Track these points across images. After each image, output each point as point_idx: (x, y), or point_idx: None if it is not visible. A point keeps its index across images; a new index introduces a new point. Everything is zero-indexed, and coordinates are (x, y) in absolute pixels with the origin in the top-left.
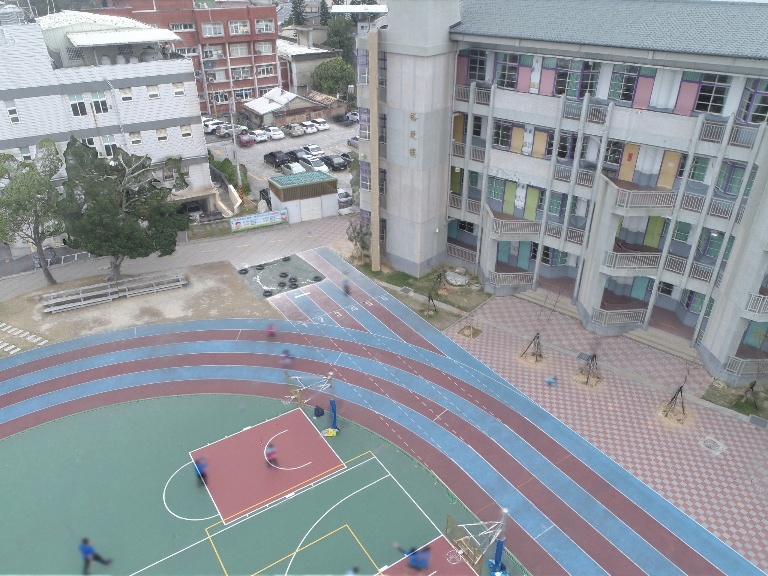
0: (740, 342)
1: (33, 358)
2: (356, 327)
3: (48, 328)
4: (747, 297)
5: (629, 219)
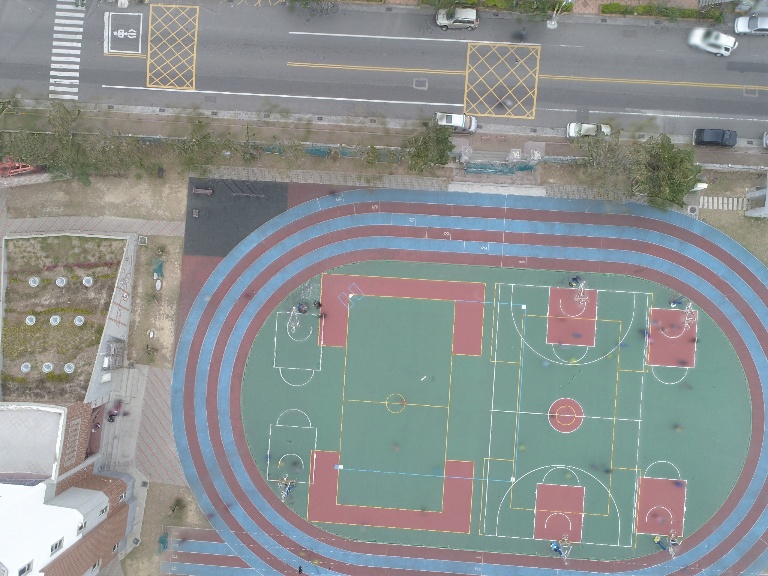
0: None
1: None
2: None
3: None
4: None
5: None
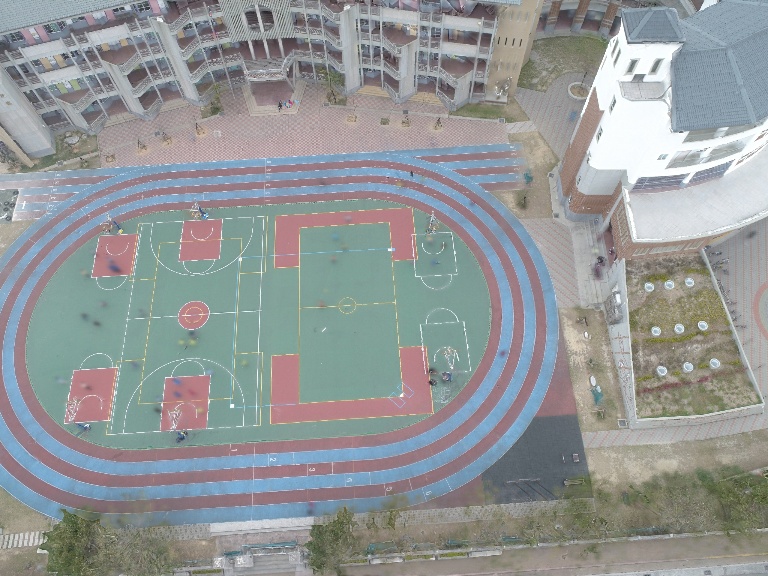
0: (197, 90)
1: None
2: (69, 196)
3: None
4: (188, 77)
5: None
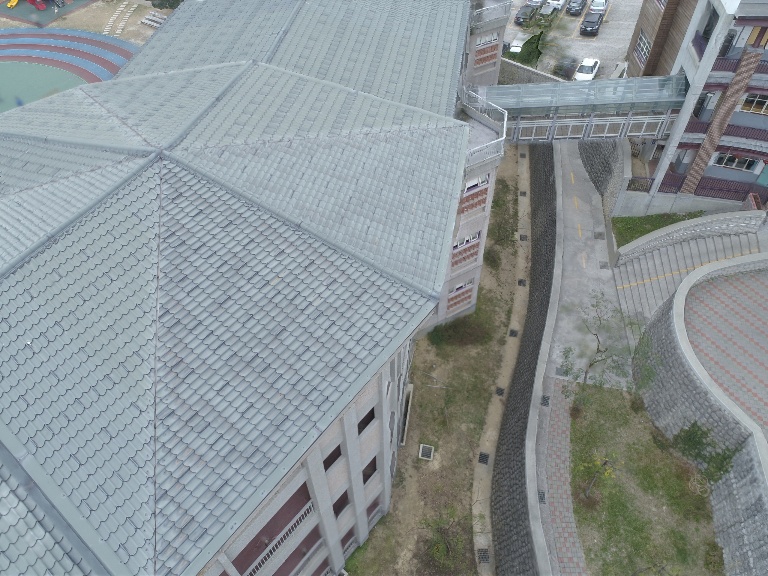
0: None
1: (102, 40)
2: None
3: (130, 30)
4: None
5: None
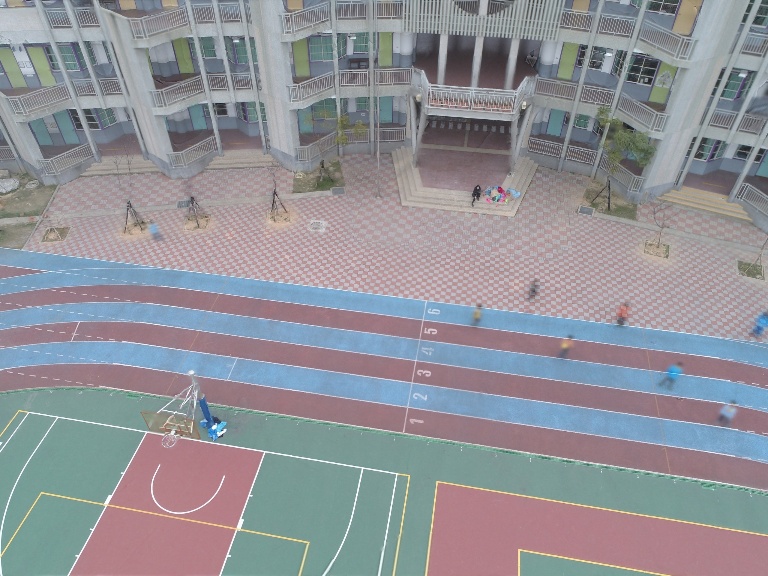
0: (298, 132)
1: None
2: None
3: None
4: (287, 90)
5: (154, 51)
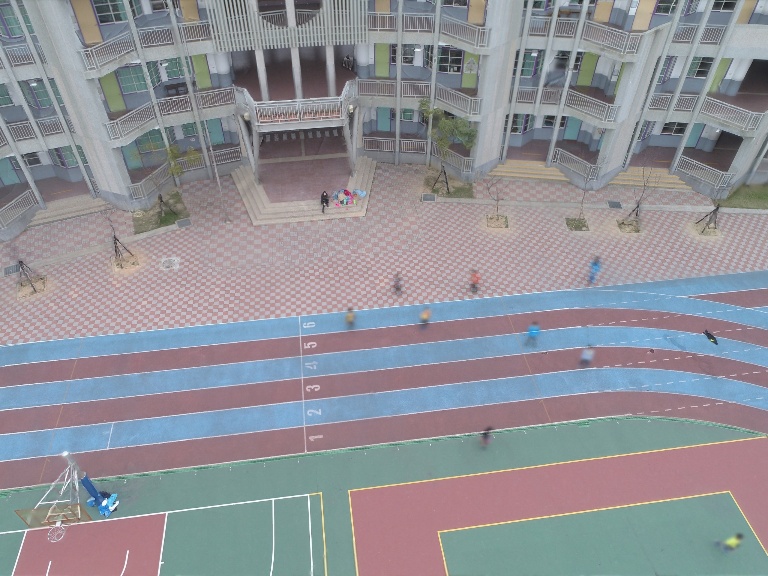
0: (127, 170)
1: None
2: None
3: None
4: (104, 129)
5: None
